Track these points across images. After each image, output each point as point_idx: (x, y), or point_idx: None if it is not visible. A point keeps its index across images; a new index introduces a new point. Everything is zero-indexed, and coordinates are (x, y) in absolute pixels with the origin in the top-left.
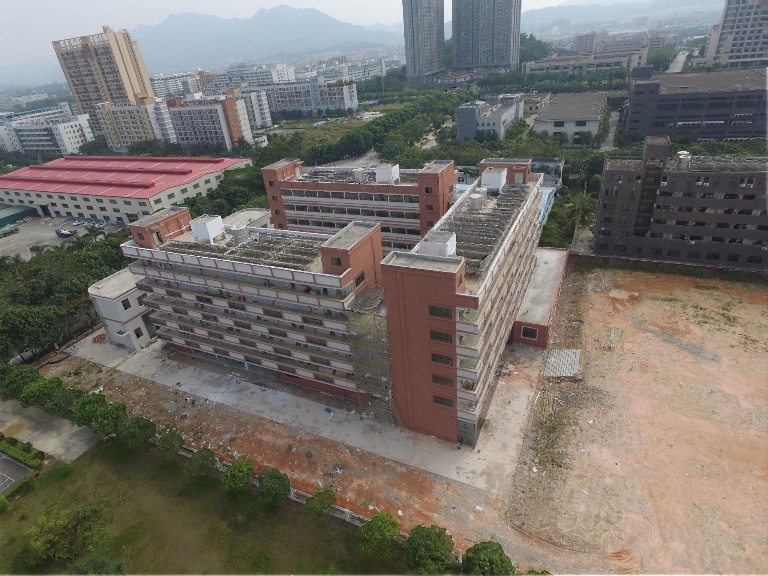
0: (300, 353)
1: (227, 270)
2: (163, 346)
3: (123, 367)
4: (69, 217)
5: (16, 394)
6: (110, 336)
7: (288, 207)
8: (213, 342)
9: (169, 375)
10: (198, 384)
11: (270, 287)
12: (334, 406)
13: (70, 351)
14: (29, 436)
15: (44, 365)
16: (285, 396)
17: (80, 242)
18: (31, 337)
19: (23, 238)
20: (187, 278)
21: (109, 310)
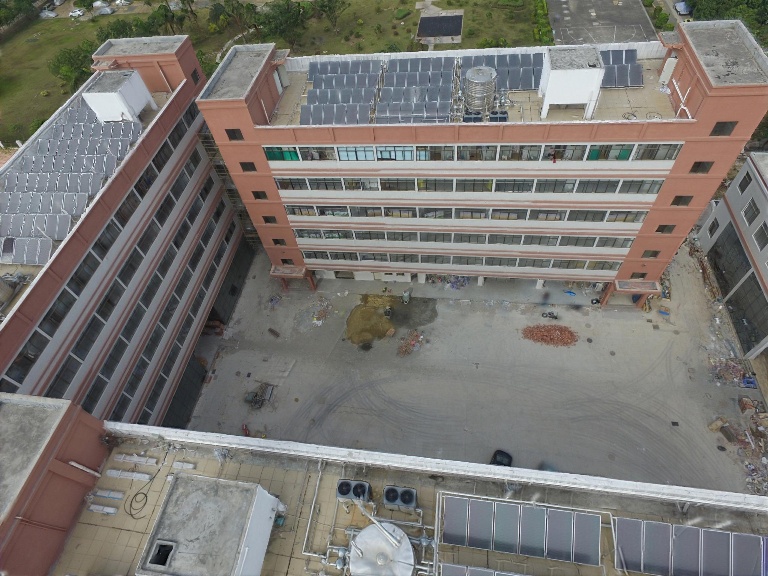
0: None
1: None
2: None
3: None
4: None
5: None
6: None
7: None
8: None
9: None
10: None
11: None
12: None
13: None
14: None
15: None
16: None
17: None
18: None
19: None
20: None
21: None
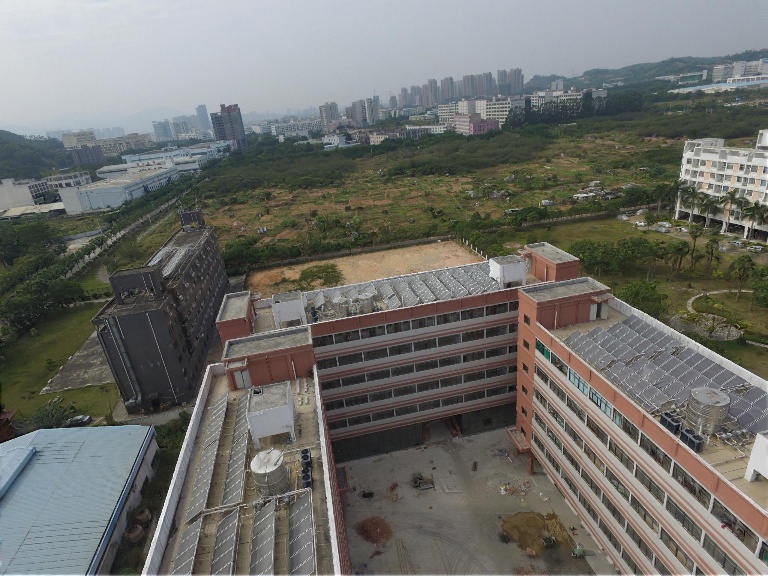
0: None
1: None
2: None
3: None
4: None
5: None
6: None
7: None
8: None
9: None
10: None
11: None
12: None
13: None
14: None
15: None
16: None
17: None
18: None
19: None
20: None
21: None
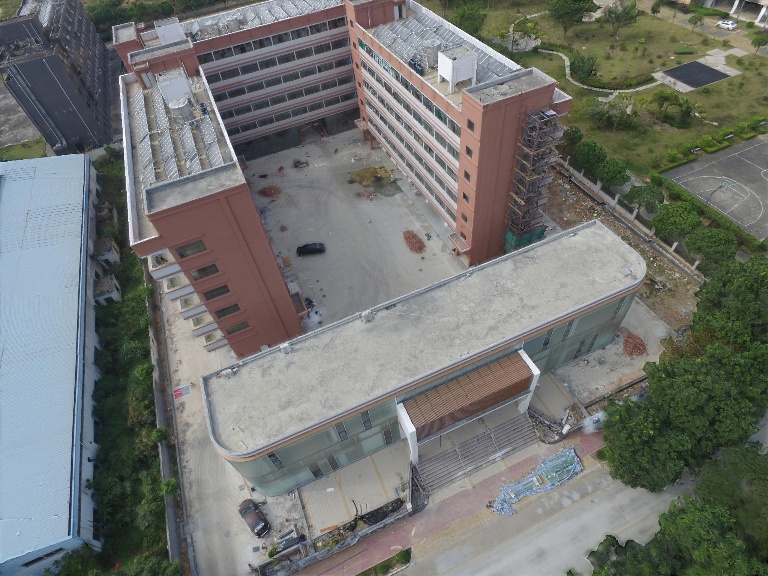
0: None
1: None
2: None
3: None
4: None
5: None
6: None
7: None
8: None
9: None
10: None
11: None
12: None
13: None
14: None
15: None
16: None
17: None
18: None
19: None
20: None
21: None
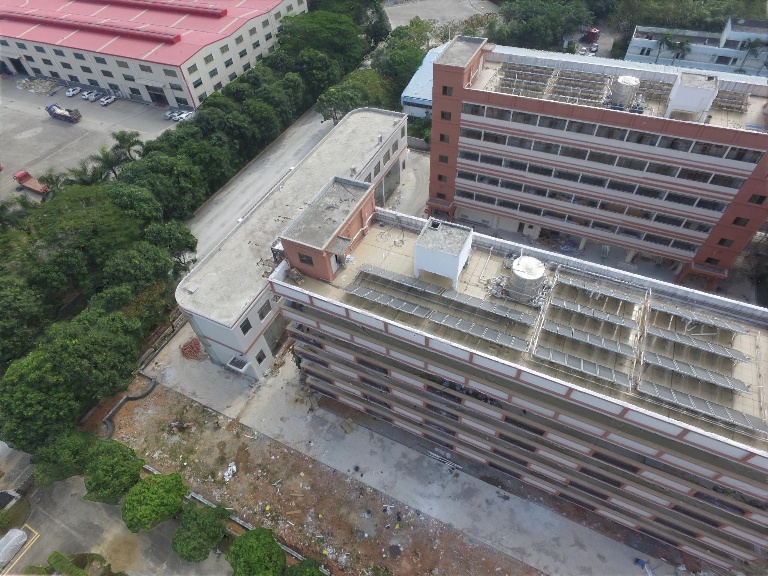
0: (634, 507)
1: (544, 390)
2: (299, 375)
3: (252, 420)
4: (56, 80)
5: (112, 500)
6: (213, 355)
7: (468, 133)
8: (425, 426)
9: (334, 446)
10: (390, 472)
11: (644, 437)
12: (643, 549)
13: (154, 374)
14: (153, 575)
15: (122, 403)
16: (549, 517)
17: (109, 160)
18: (105, 389)
19: (0, 116)
20: (420, 363)
21: (217, 333)
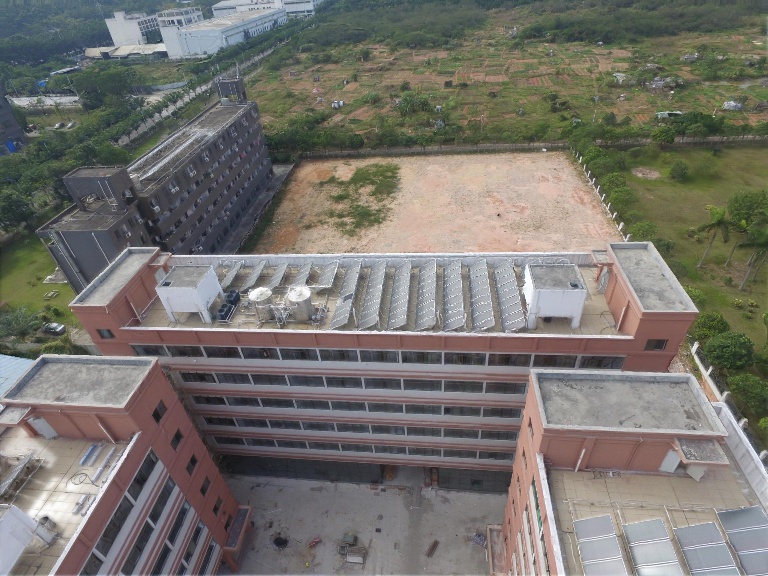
0: None
1: None
2: None
3: None
4: None
5: None
6: None
7: None
8: None
9: None
10: None
11: None
12: None
13: None
14: None
15: None
16: None
17: None
18: None
19: None
20: None
21: None
